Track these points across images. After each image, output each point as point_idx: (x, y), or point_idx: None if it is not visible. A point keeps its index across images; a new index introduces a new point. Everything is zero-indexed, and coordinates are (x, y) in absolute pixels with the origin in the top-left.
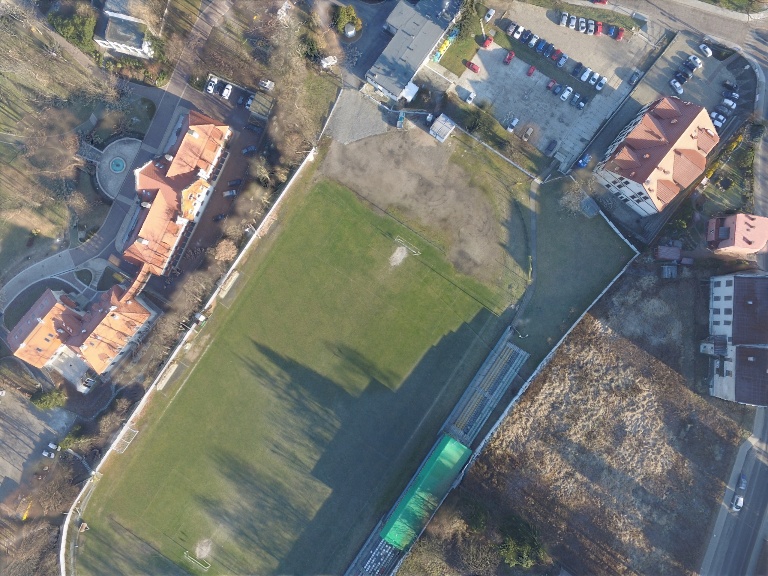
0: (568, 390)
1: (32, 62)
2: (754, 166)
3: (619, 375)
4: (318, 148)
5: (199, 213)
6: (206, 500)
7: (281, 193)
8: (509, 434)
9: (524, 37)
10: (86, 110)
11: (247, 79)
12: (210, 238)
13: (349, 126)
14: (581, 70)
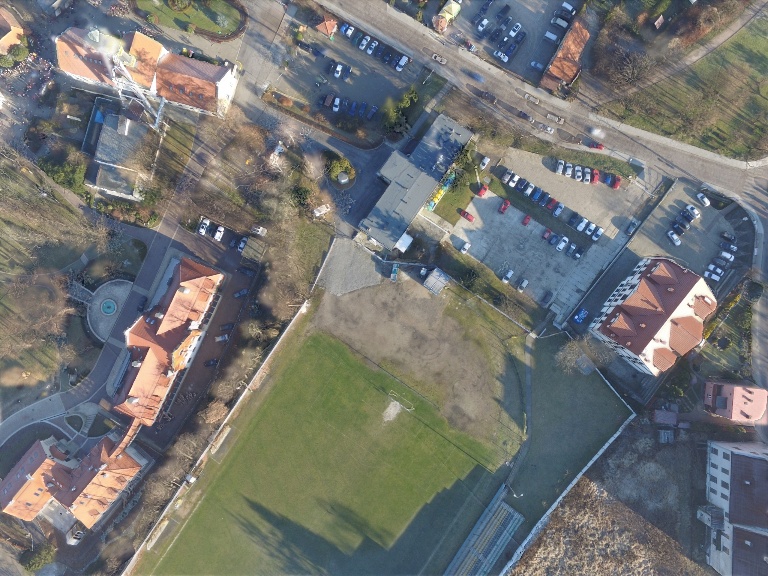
0: (563, 555)
1: (22, 201)
2: (752, 324)
3: (615, 541)
4: (311, 299)
5: (191, 358)
6: None
7: (273, 347)
8: None
9: (519, 186)
10: (77, 250)
11: (239, 222)
12: (202, 383)
13: (342, 277)
14: (577, 220)
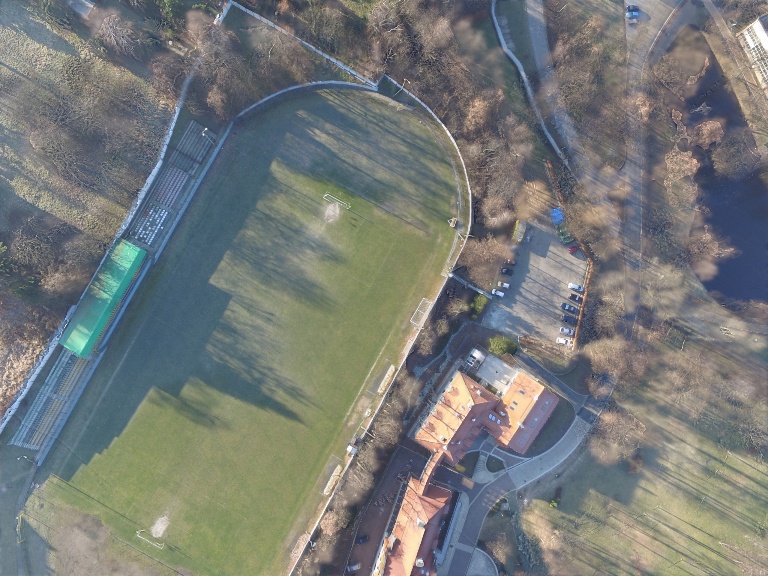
0: None
1: None
2: None
3: None
4: None
5: None
6: (335, 260)
7: None
8: (26, 361)
9: None
10: None
11: None
12: (370, 517)
13: None
14: None
